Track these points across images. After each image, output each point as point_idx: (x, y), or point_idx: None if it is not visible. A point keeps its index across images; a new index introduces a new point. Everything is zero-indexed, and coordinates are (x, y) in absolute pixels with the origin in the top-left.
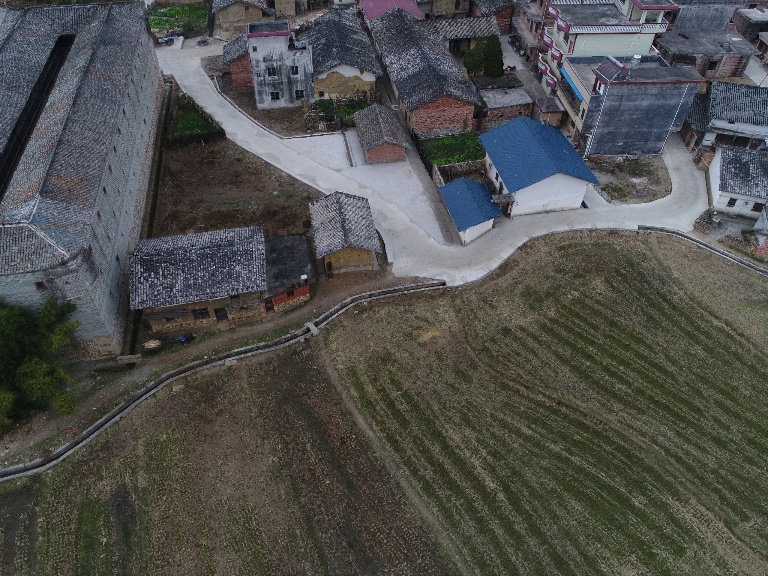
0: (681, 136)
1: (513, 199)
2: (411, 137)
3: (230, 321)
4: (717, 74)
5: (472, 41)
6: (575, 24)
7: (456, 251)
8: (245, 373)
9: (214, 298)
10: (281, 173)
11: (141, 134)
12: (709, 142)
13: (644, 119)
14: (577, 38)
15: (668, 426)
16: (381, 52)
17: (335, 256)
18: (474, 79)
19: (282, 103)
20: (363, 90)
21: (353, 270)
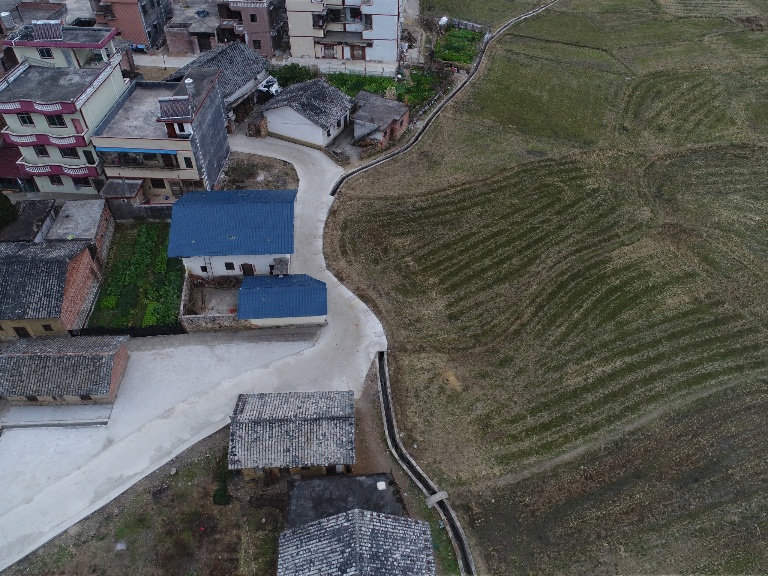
0: None
1: (286, 259)
2: None
3: None
4: None
5: None
6: None
7: (332, 333)
8: None
9: None
10: (69, 534)
11: None
12: None
13: (214, 131)
14: (82, 111)
15: (550, 247)
16: None
17: None
18: (3, 239)
19: None
20: None
21: None
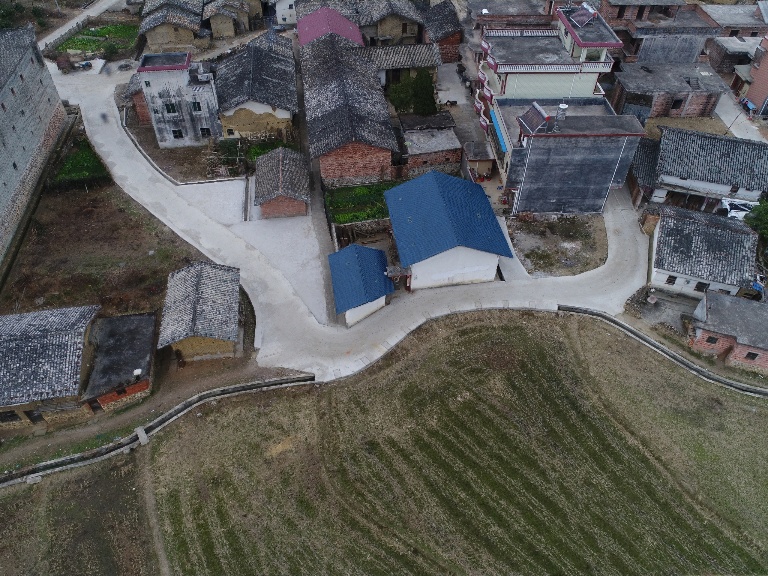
0: (629, 190)
1: (410, 272)
2: (320, 185)
3: (49, 422)
4: (683, 113)
5: (411, 71)
6: (507, 61)
7: (337, 335)
8: (47, 495)
9: (12, 404)
10: (163, 228)
11: (5, 182)
12: (659, 199)
13: (578, 174)
14: (508, 77)
15: None
16: (303, 84)
17: (183, 344)
18: (402, 117)
19: (187, 141)
20: (278, 128)
21: (210, 357)
